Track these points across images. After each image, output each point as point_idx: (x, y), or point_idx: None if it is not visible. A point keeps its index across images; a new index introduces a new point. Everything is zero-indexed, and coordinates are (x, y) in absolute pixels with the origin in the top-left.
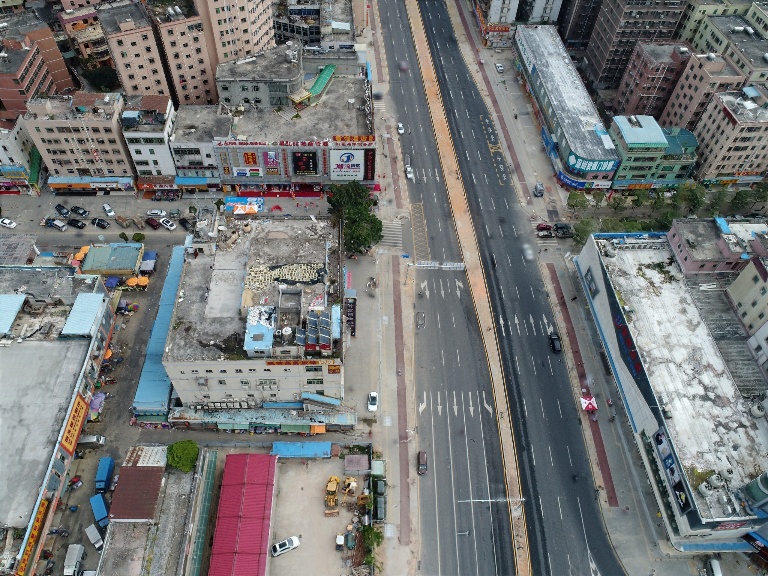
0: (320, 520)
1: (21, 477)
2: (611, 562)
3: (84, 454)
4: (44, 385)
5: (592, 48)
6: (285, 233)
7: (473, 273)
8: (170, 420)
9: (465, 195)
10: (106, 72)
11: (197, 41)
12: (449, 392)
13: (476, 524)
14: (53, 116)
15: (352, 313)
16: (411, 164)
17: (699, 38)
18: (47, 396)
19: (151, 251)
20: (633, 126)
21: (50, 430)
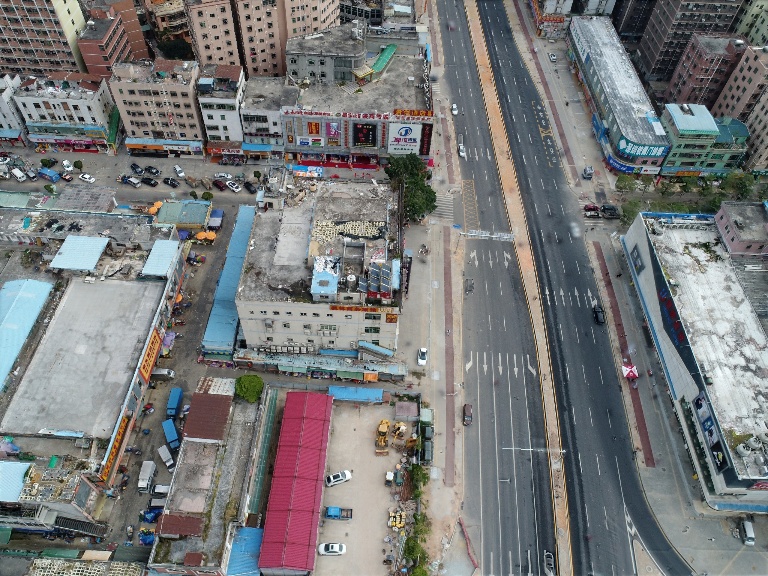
0: (371, 458)
1: (104, 396)
2: (646, 517)
3: (156, 385)
4: (124, 319)
5: (646, 40)
6: (348, 194)
7: (521, 246)
8: (235, 359)
9: (515, 174)
10: (180, 44)
11: (270, 16)
12: (495, 353)
13: (517, 473)
14: (135, 80)
15: (407, 273)
16: (464, 143)
17: (755, 32)
18: (127, 328)
19: (218, 209)
20: (685, 114)
21: (130, 358)
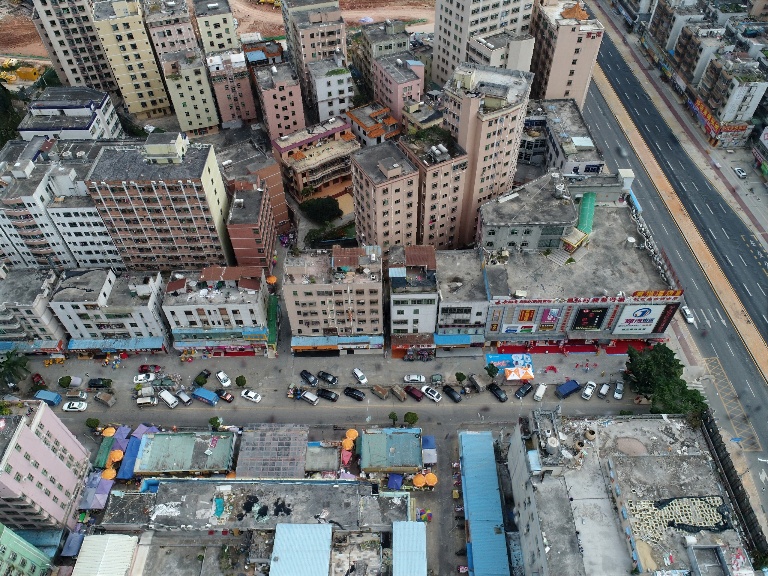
0: None
1: None
2: None
3: None
4: None
5: None
6: (637, 440)
7: None
8: None
9: (766, 345)
10: (329, 205)
11: (457, 180)
12: None
13: None
14: (311, 277)
15: None
16: None
17: None
18: None
19: (429, 436)
20: None
21: None
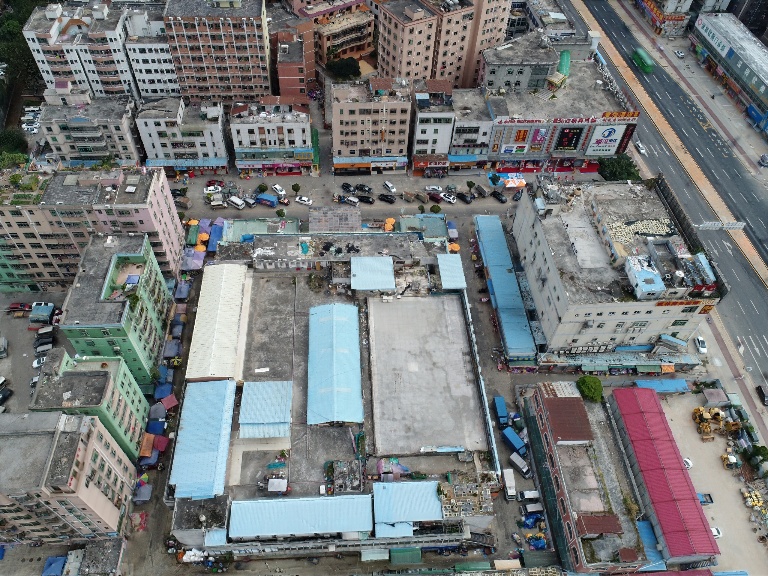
0: (699, 445)
1: (460, 410)
2: None
3: None
4: (439, 333)
5: None
6: (610, 196)
7: (736, 234)
8: (541, 364)
9: (698, 167)
10: (352, 62)
11: (465, 29)
12: (759, 336)
13: None
14: (354, 99)
15: None
16: None
17: None
18: (446, 343)
19: (450, 221)
20: None
21: (464, 371)
